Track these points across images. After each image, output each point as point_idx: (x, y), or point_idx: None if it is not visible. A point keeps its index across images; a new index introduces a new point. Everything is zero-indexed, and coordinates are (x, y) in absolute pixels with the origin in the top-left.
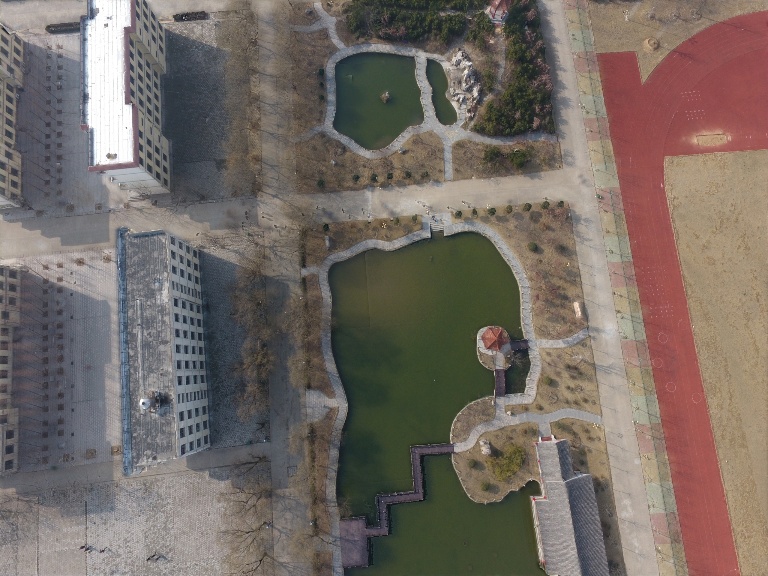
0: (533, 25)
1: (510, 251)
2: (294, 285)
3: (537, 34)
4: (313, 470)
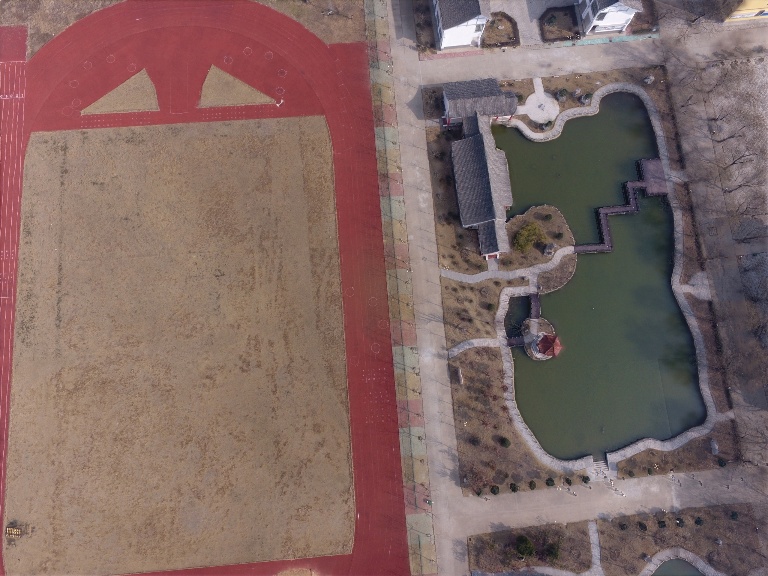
0: None
1: (525, 439)
2: (739, 401)
3: None
4: (696, 232)
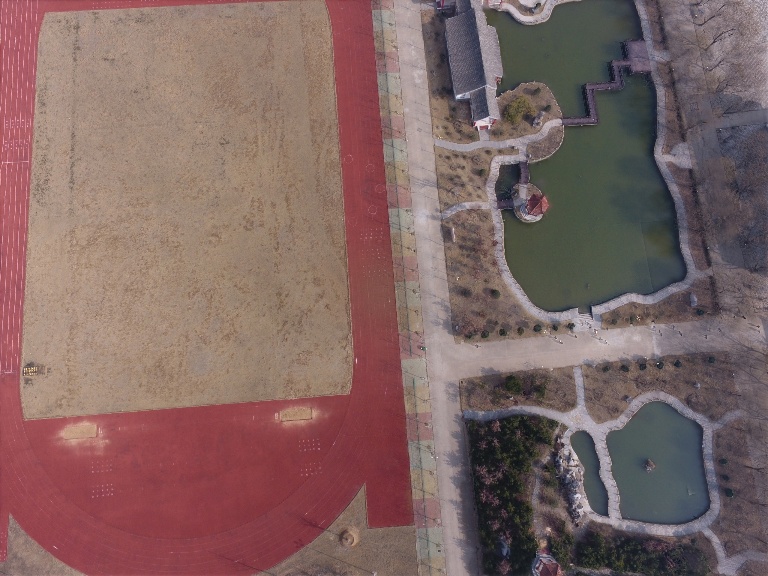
0: (497, 557)
1: (514, 292)
2: (717, 260)
3: (493, 543)
4: (677, 107)
